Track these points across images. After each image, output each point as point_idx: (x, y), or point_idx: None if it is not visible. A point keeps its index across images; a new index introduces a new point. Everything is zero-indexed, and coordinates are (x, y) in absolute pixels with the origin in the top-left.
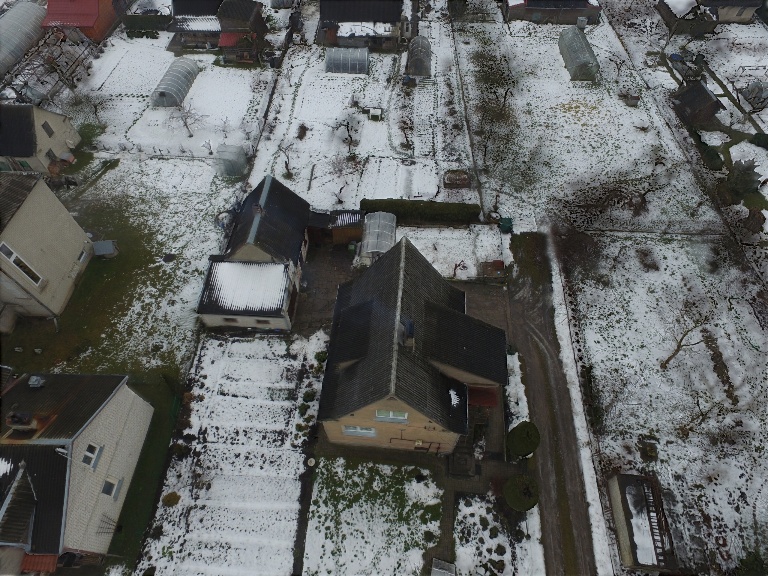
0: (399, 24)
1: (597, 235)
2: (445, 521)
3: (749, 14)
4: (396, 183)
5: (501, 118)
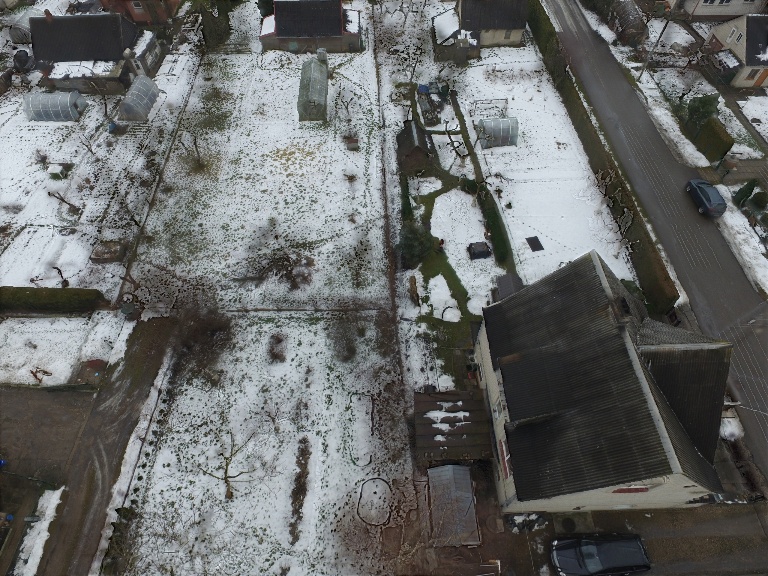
0: (122, 62)
1: (238, 317)
2: None
3: (517, 37)
4: (39, 259)
5: (200, 170)
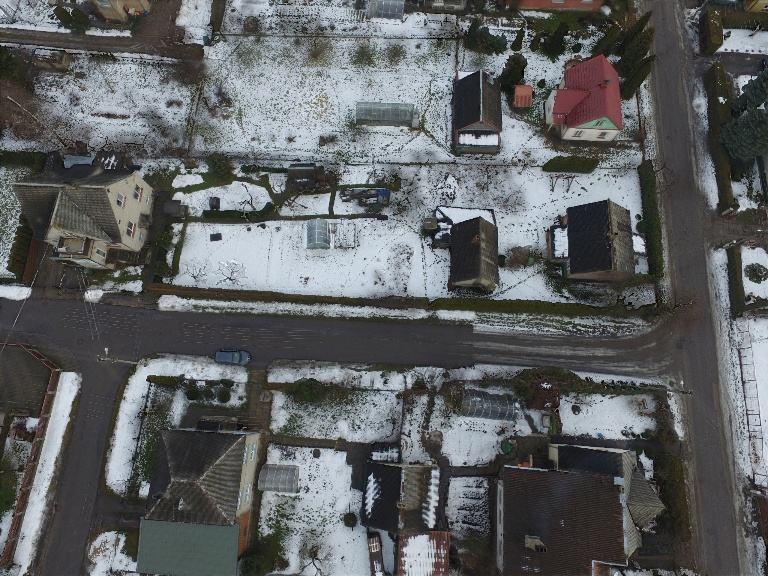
0: None
1: None
2: (70, 5)
3: None
4: None
5: (312, 56)
